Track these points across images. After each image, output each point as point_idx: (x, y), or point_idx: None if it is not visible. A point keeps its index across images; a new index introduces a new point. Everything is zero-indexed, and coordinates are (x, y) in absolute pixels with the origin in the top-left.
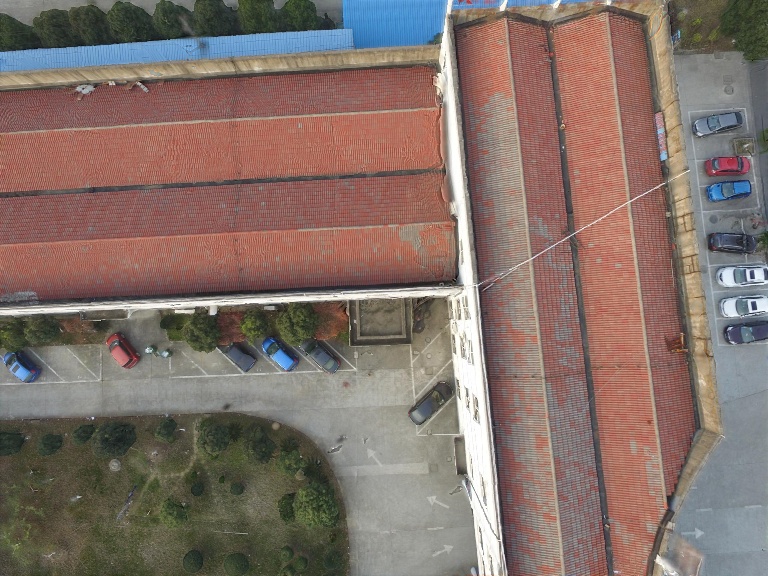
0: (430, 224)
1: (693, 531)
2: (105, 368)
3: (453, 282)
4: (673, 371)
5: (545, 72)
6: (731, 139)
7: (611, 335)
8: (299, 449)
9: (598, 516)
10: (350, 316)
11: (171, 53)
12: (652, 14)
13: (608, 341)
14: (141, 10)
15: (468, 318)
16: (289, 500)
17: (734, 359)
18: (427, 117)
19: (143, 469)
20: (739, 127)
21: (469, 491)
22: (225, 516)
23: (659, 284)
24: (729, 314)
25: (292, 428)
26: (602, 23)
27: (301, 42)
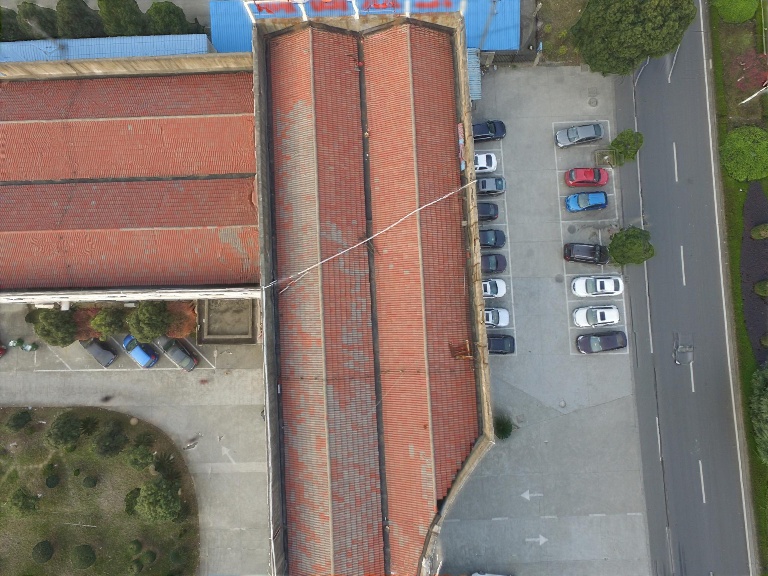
0: (248, 227)
1: (537, 538)
2: None
3: None
4: (456, 377)
5: (352, 81)
6: (593, 151)
7: (398, 340)
8: (155, 445)
9: (378, 518)
10: (199, 315)
11: (28, 54)
12: (458, 27)
13: (395, 346)
14: (7, 11)
15: None
16: (136, 494)
17: (586, 368)
18: (250, 122)
19: (3, 460)
20: (599, 139)
21: None
22: (80, 508)
23: (446, 291)
24: (580, 323)
25: (150, 424)
26: (404, 35)
27: (157, 46)
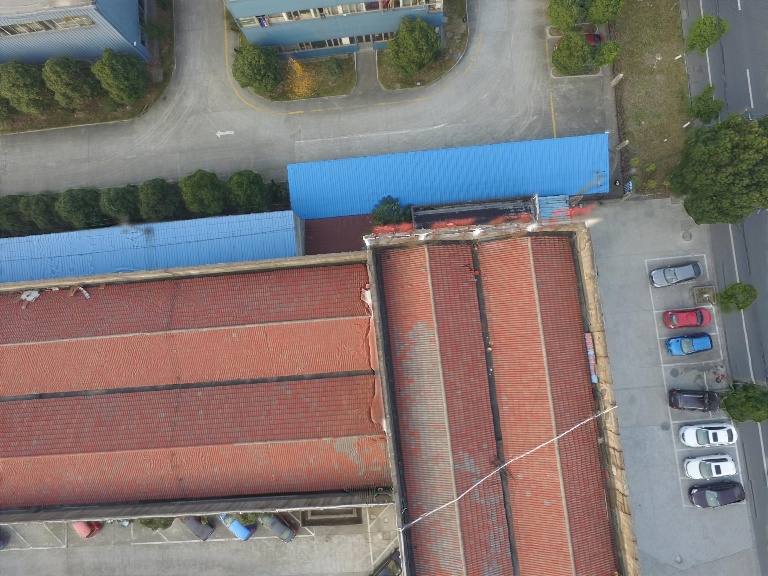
0: (364, 437)
1: None
2: (70, 534)
3: (391, 491)
4: None
5: (470, 293)
6: (691, 288)
7: (542, 574)
8: None
9: None
10: None
11: (116, 244)
12: None
13: None
14: (89, 195)
15: None
16: None
17: (701, 521)
18: (358, 326)
19: None
20: None
21: None
22: None
23: (591, 521)
24: (693, 476)
25: None
26: (524, 247)
27: (243, 225)
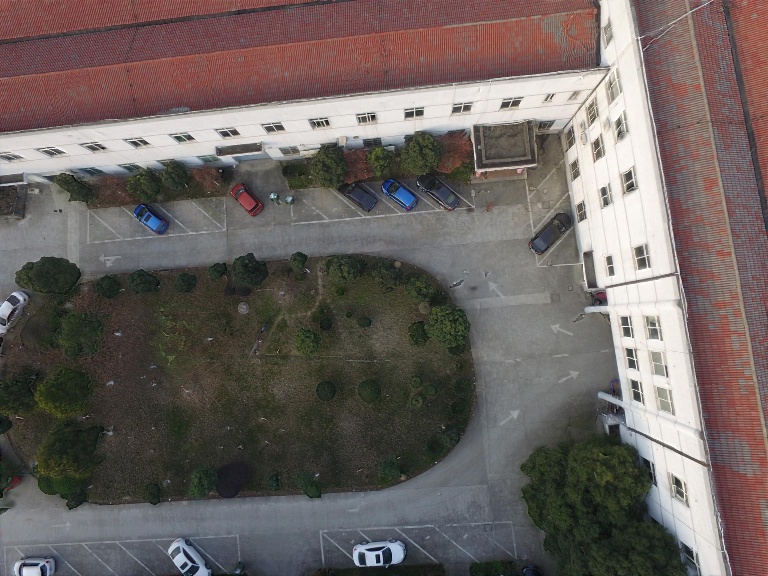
0: (572, 13)
1: None
2: (229, 218)
3: (594, 72)
4: None
5: None
6: None
7: None
8: None
9: (767, 258)
10: (475, 142)
11: None
12: None
13: None
14: None
15: (614, 100)
16: (419, 325)
17: None
18: None
19: (271, 310)
20: None
21: (601, 303)
22: (352, 351)
23: None
24: None
25: (413, 266)
26: None
27: None
